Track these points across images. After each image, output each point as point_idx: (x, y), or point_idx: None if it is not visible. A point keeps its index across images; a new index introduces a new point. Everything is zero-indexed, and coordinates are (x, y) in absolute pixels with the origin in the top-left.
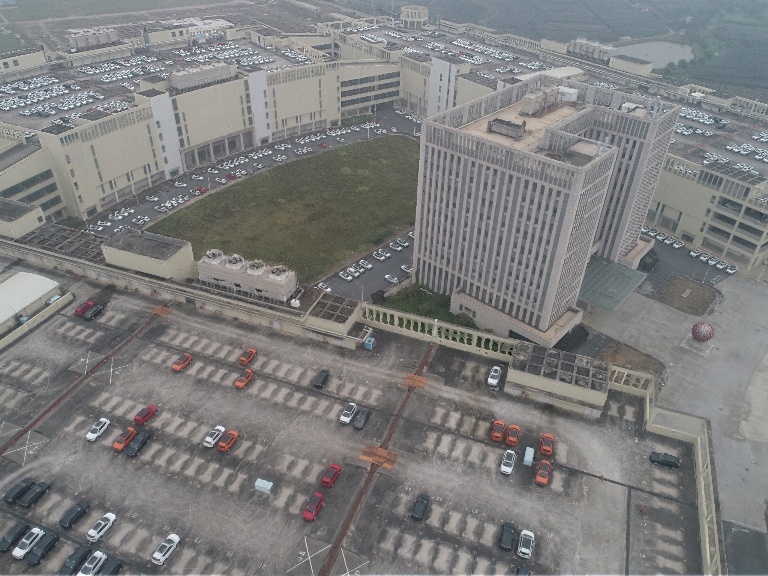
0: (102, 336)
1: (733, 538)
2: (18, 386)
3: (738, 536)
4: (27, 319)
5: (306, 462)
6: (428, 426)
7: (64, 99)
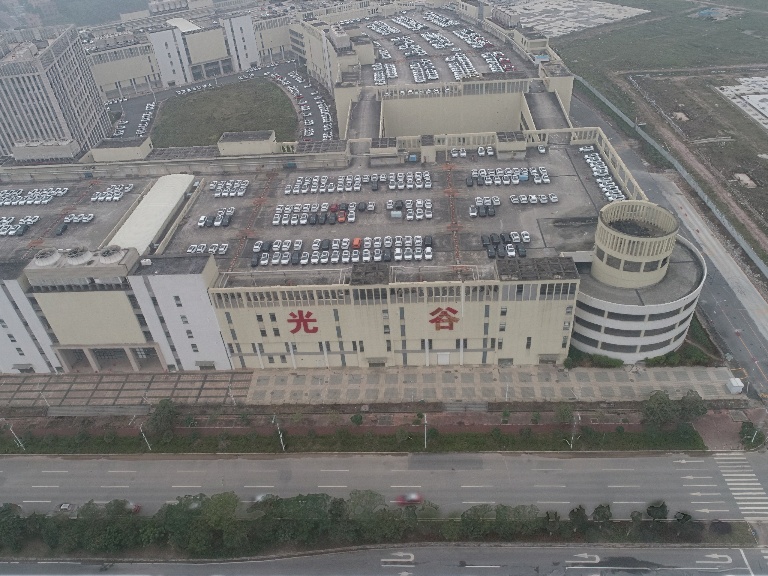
0: None
1: None
2: None
3: None
4: None
5: None
6: None
7: None
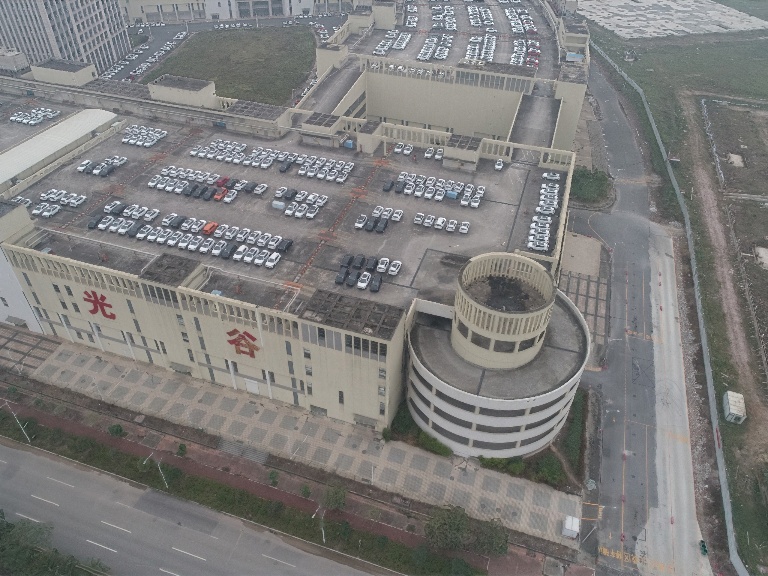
0: None
1: None
2: None
3: None
4: None
5: None
6: None
7: None
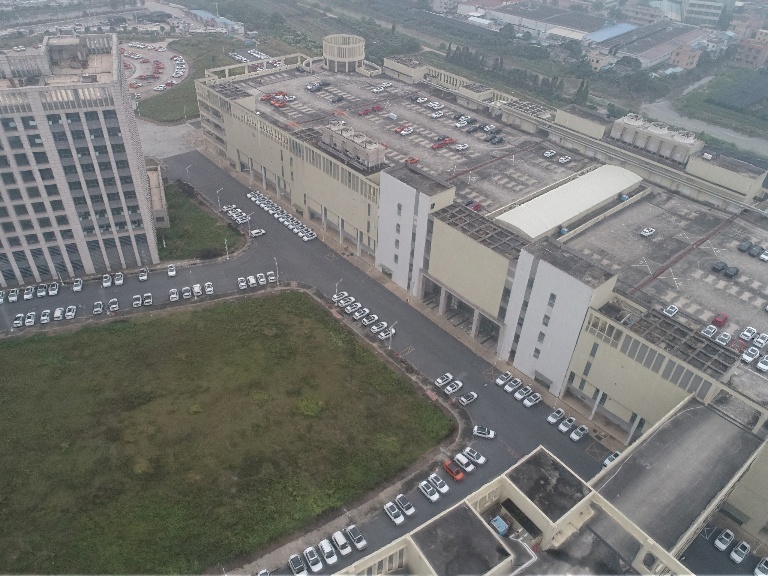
0: (460, 190)
1: None
2: (510, 177)
3: None
4: (515, 205)
5: (371, 119)
6: (307, 115)
7: None
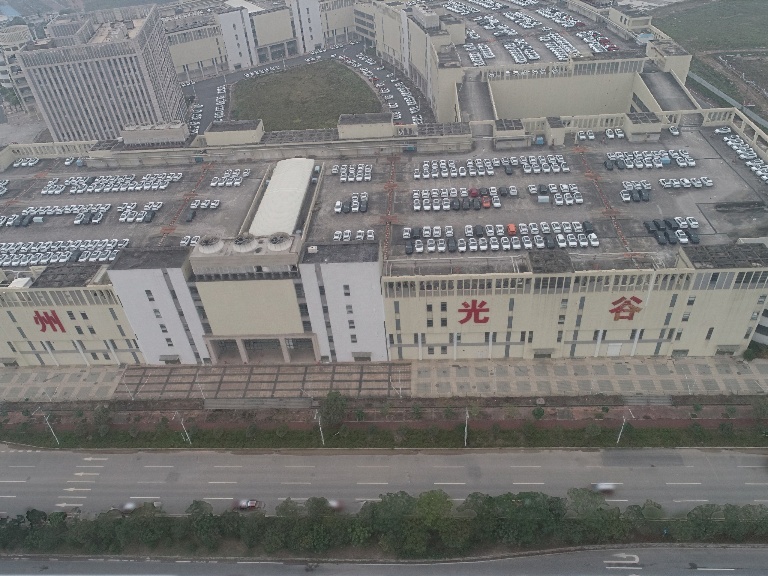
0: None
1: (4, 121)
2: None
3: (2, 122)
4: None
5: None
6: None
7: (464, 5)
